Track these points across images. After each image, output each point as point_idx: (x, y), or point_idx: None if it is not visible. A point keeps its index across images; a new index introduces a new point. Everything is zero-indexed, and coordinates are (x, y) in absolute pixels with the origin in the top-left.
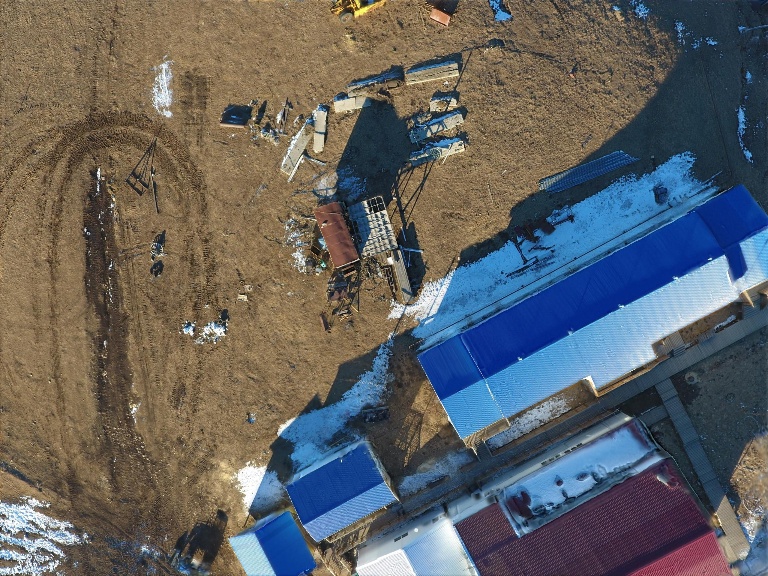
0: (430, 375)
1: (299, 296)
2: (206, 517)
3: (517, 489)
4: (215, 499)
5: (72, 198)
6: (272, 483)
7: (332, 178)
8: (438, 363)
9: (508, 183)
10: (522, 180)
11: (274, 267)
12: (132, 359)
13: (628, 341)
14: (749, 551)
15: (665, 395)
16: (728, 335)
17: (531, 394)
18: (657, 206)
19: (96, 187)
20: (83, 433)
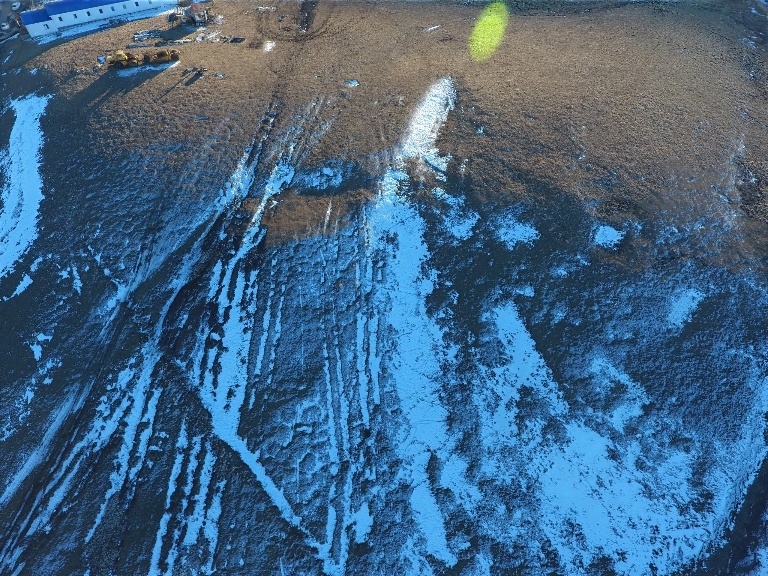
0: None
1: None
2: None
3: None
4: None
5: (317, 26)
6: None
7: None
8: None
9: None
10: None
11: None
12: None
13: None
14: None
15: None
16: None
17: None
18: None
19: None
20: None
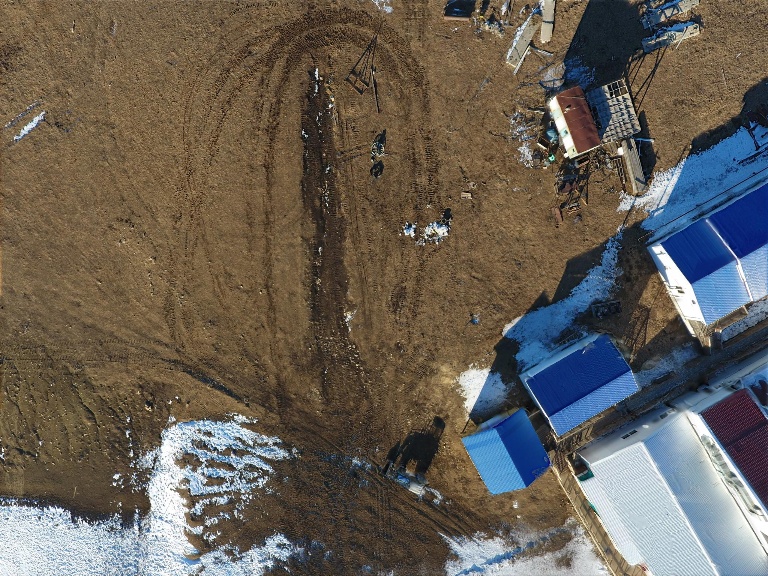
0: (676, 260)
1: (525, 191)
2: (421, 425)
3: (755, 378)
4: (432, 405)
5: (290, 100)
6: (495, 385)
7: (559, 69)
8: (683, 248)
9: (742, 67)
10: (756, 63)
11: (499, 163)
12: (349, 264)
13: None
14: None
15: None
16: None
17: None
18: None
19: (314, 88)
20: (293, 344)
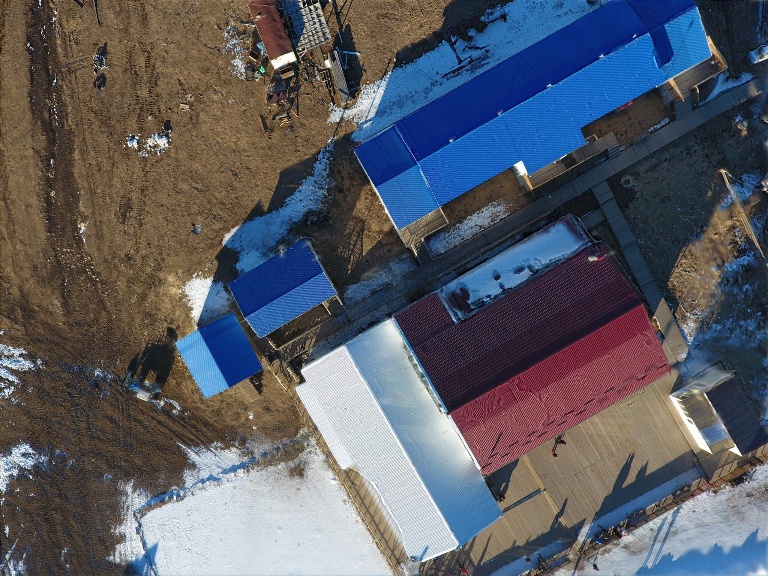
0: (366, 165)
1: (240, 103)
2: (157, 336)
3: (456, 285)
4: (164, 316)
5: (14, 12)
6: (219, 294)
7: None
8: (373, 154)
9: None
10: None
11: (214, 75)
12: (79, 176)
13: (558, 125)
14: (687, 353)
15: (602, 198)
16: (662, 136)
17: (464, 179)
18: (589, 6)
19: (38, 1)
20: (34, 256)
